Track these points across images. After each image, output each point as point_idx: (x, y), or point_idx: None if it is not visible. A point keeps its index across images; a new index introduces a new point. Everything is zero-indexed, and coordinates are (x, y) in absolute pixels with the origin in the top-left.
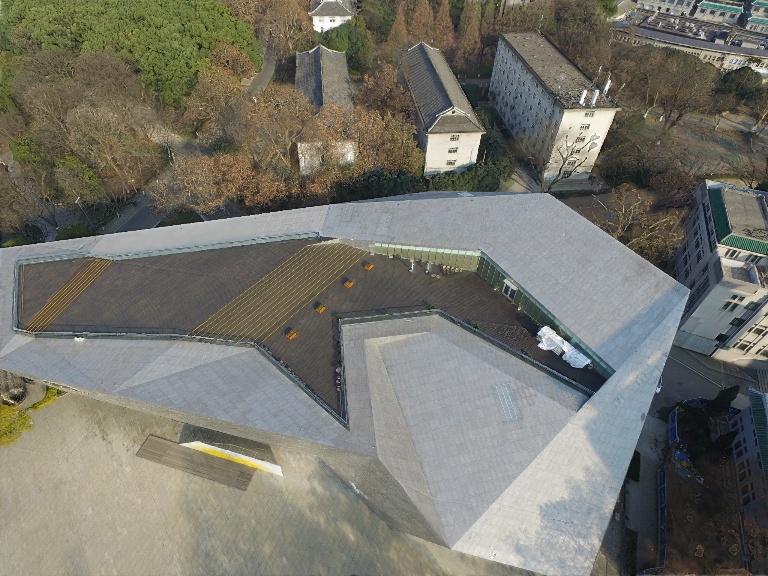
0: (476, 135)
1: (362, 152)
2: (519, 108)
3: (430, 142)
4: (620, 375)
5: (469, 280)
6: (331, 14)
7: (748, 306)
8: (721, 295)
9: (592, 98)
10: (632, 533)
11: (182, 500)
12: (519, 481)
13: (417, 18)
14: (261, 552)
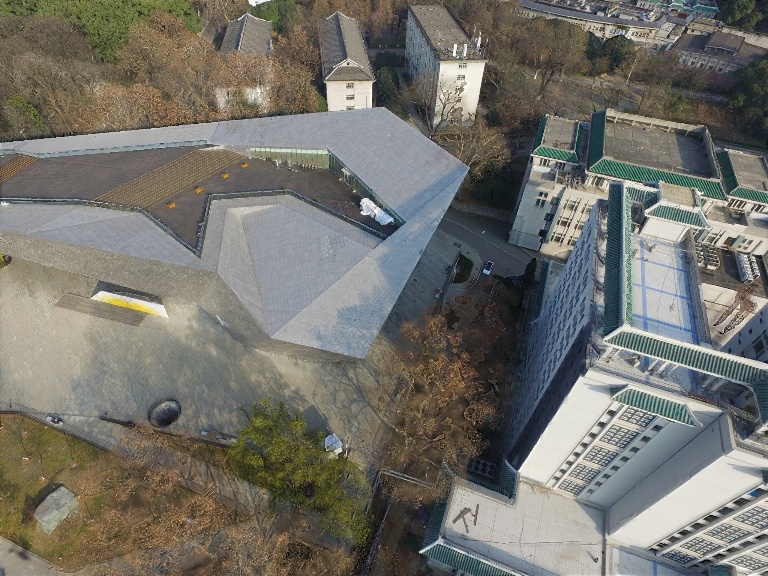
0: (368, 83)
1: (264, 92)
2: (420, 68)
3: (329, 89)
4: (409, 225)
5: (321, 174)
6: None
7: (552, 202)
8: (532, 193)
9: (463, 51)
10: None
11: (87, 332)
12: (325, 294)
13: None
14: (143, 361)
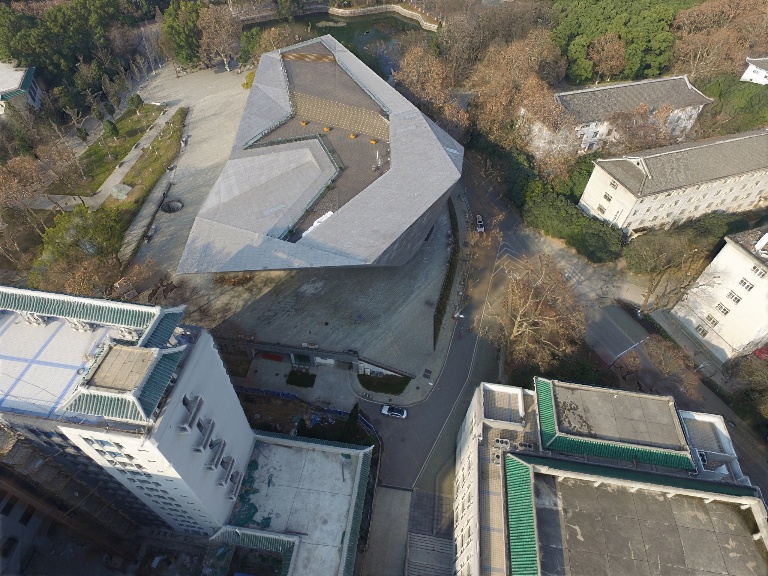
0: (632, 196)
1: None
2: None
3: (595, 173)
4: (292, 246)
5: None
6: None
7: None
8: None
9: None
10: (245, 374)
11: None
12: (226, 227)
13: None
14: None
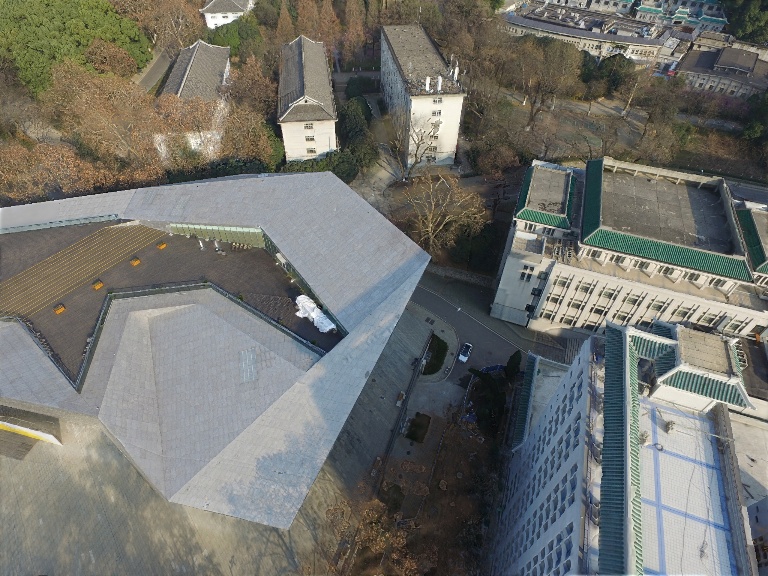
0: (329, 123)
1: (204, 141)
2: (394, 98)
3: (285, 131)
4: (352, 336)
5: (255, 256)
6: (223, 11)
7: (540, 276)
8: (515, 266)
9: (437, 85)
10: None
11: None
12: (242, 436)
13: (301, 13)
14: (20, 515)
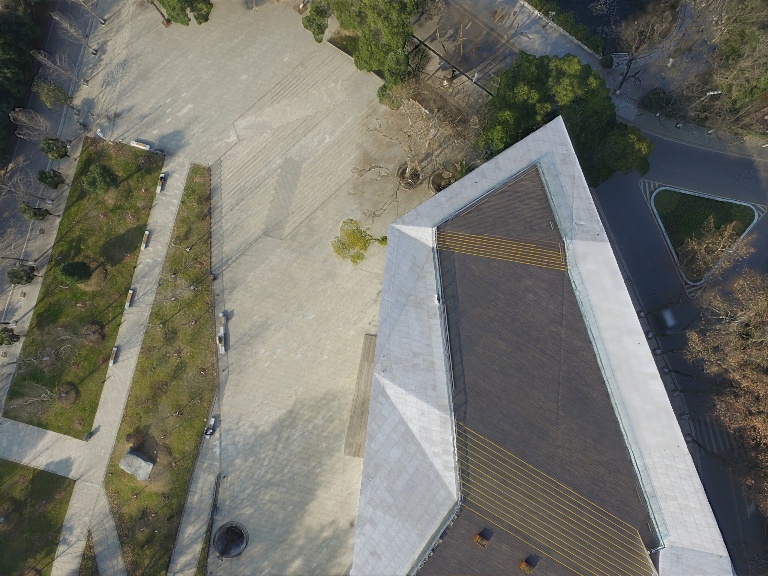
0: None
1: None
2: None
3: None
4: None
5: None
6: None
7: None
8: None
9: None
10: None
11: (329, 397)
12: None
13: None
14: (294, 485)
